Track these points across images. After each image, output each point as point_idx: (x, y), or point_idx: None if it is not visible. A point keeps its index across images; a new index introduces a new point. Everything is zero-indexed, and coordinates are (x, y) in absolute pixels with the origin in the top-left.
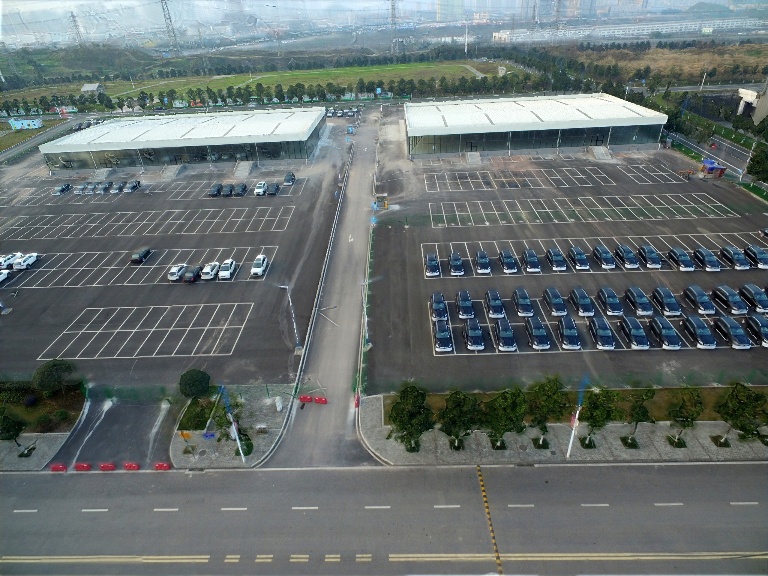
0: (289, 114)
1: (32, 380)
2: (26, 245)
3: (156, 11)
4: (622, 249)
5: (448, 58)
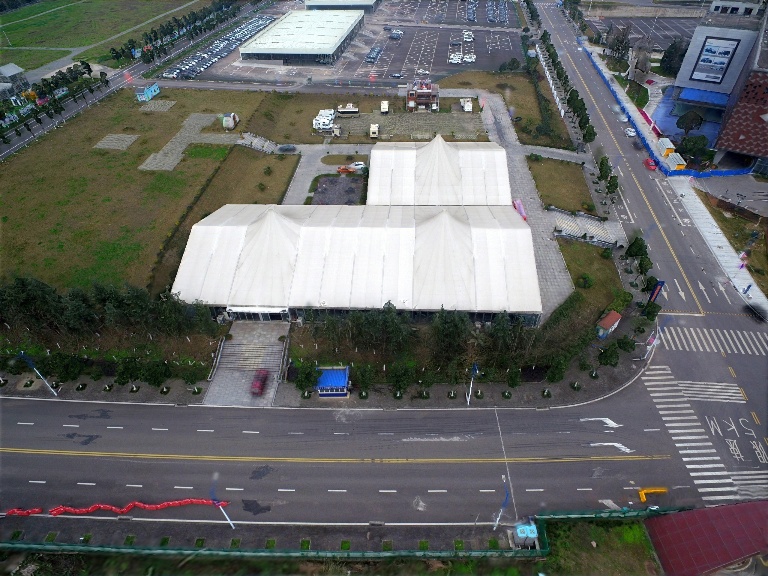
0: None
1: None
2: None
3: None
4: (470, 6)
5: None
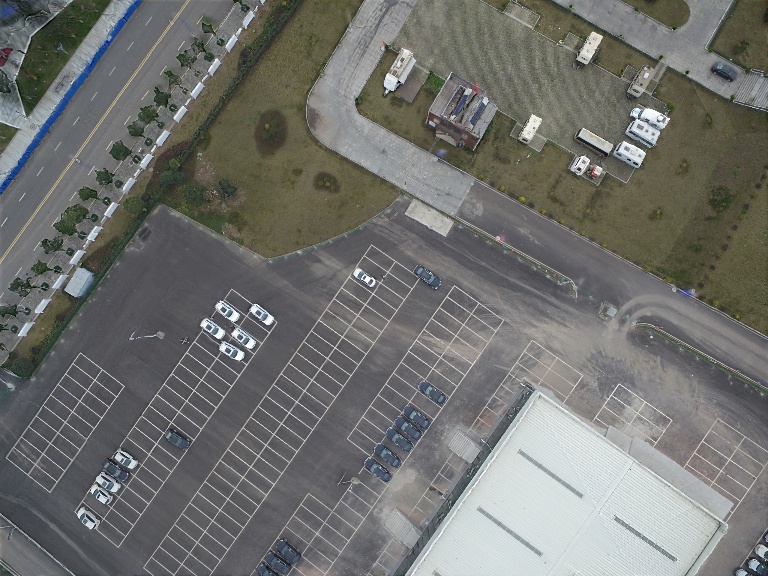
0: None
1: (20, 358)
2: (282, 350)
3: None
4: None
5: None
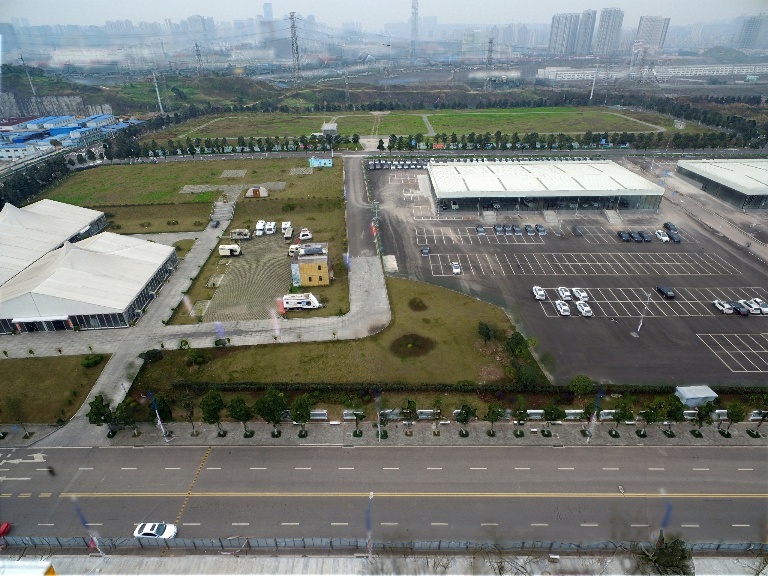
0: (588, 166)
1: None
2: (544, 280)
3: (286, 46)
4: None
5: (580, 103)
